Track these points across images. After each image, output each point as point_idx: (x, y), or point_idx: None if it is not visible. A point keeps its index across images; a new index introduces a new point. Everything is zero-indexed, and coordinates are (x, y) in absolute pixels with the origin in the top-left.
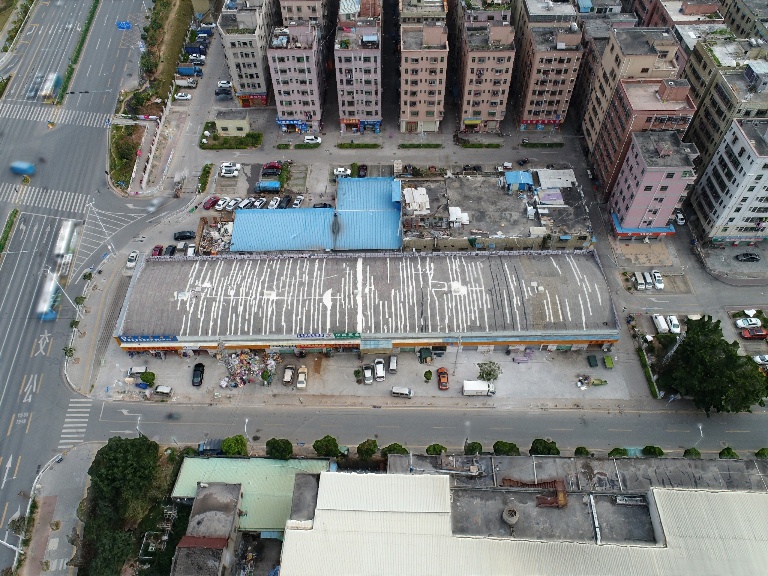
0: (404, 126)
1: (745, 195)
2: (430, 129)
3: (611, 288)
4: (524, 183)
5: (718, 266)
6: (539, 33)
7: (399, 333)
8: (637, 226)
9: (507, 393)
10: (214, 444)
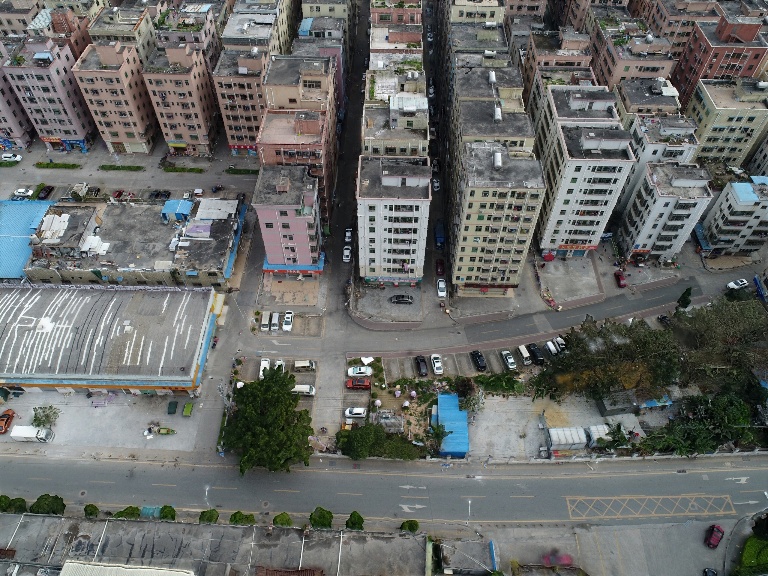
0: (111, 146)
1: (370, 236)
2: (140, 150)
3: (236, 328)
4: (179, 213)
5: (368, 307)
6: (232, 56)
7: None
8: (284, 263)
9: (66, 440)
10: None
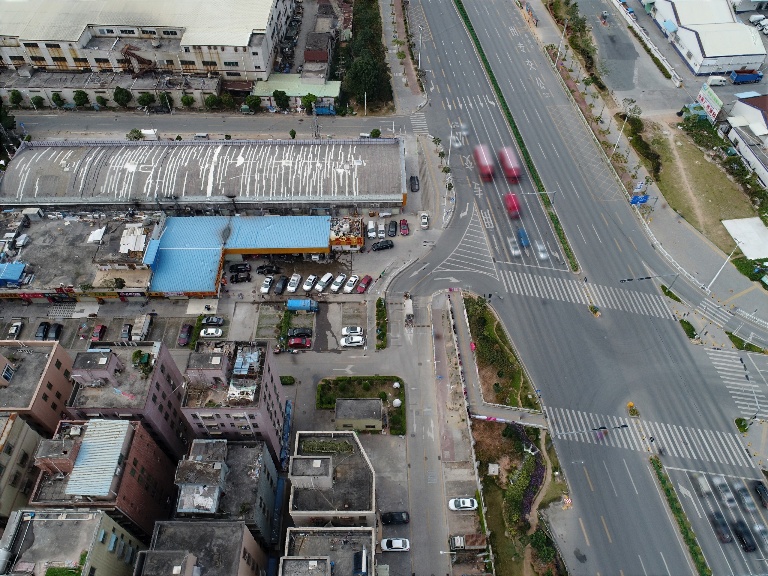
0: None
1: None
2: None
3: None
4: None
5: None
6: None
7: (190, 141)
8: None
9: None
10: (323, 104)
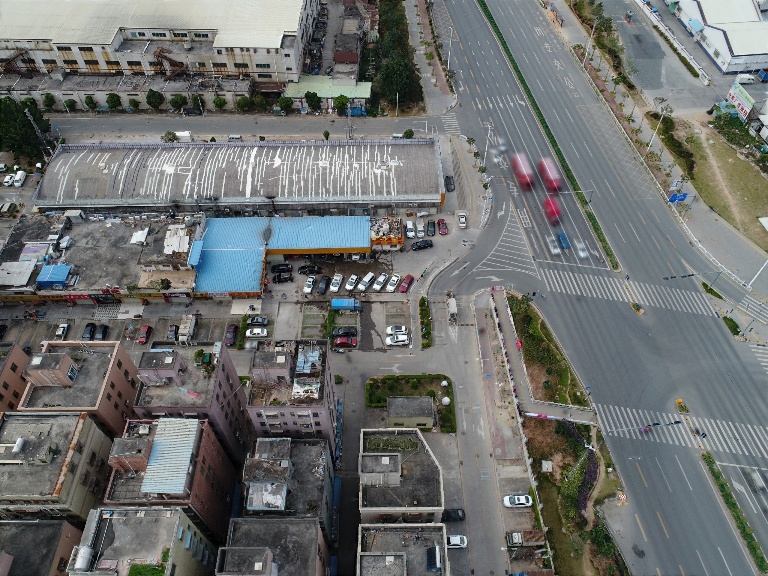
0: None
1: None
2: None
3: None
4: None
5: None
6: None
7: (226, 142)
8: None
9: None
10: (354, 105)
